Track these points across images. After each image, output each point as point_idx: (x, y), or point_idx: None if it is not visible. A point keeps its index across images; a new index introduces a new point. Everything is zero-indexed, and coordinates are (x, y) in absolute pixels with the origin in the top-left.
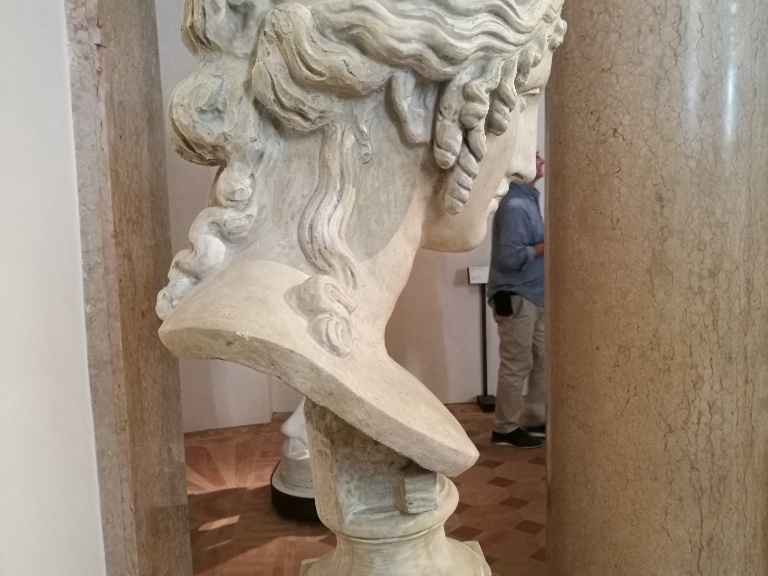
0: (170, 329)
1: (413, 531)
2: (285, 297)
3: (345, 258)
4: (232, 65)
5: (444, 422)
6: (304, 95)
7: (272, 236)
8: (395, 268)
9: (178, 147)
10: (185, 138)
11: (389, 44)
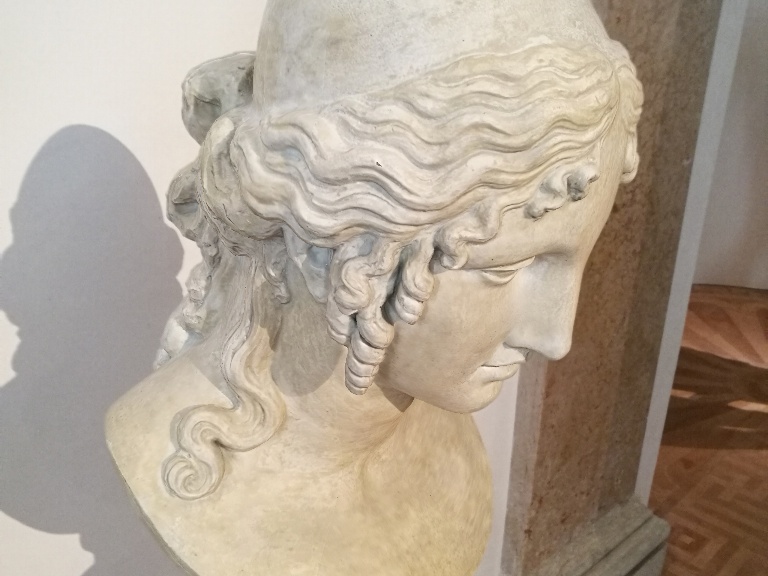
0: None
1: None
2: (176, 416)
3: (253, 394)
4: None
5: None
6: (218, 222)
7: (215, 342)
8: (336, 411)
9: None
10: None
11: (248, 202)
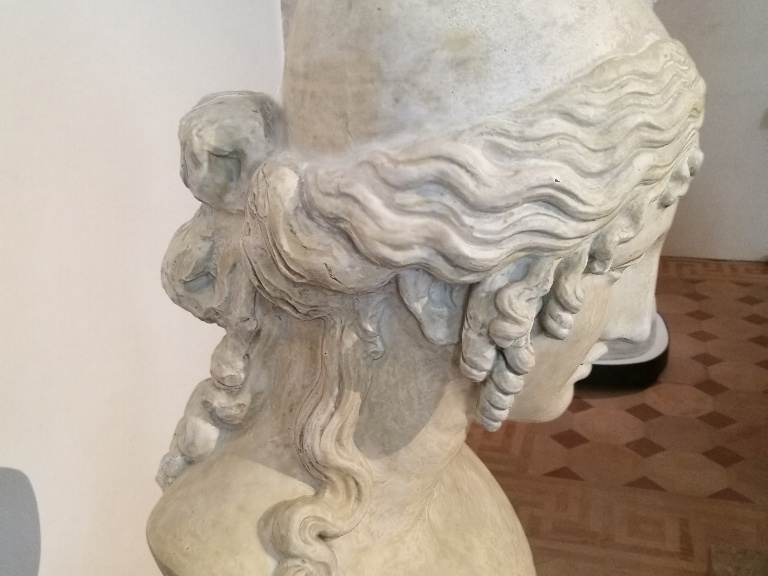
0: None
1: None
2: (260, 524)
3: (345, 469)
4: (224, 223)
5: None
6: (289, 287)
7: (267, 428)
8: (427, 459)
9: None
10: None
11: (379, 253)
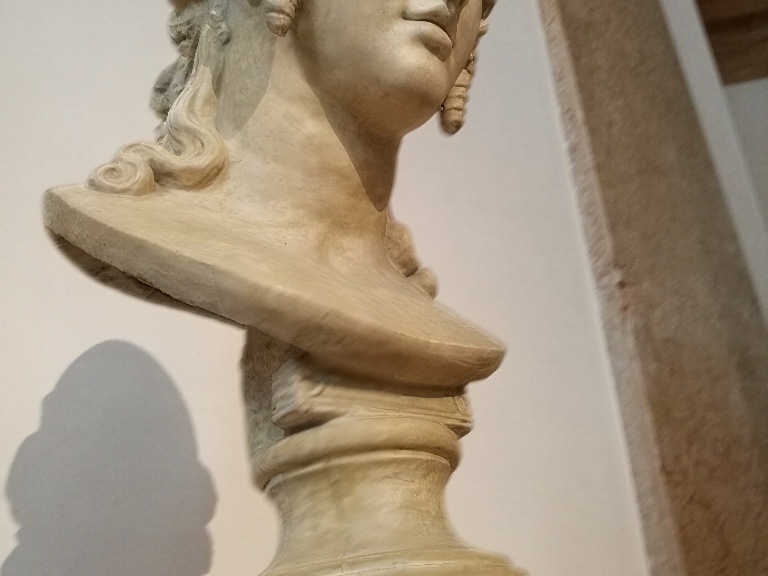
0: None
1: (285, 455)
2: None
3: (193, 131)
4: None
5: (256, 260)
6: None
7: None
8: (277, 134)
9: None
10: None
11: None
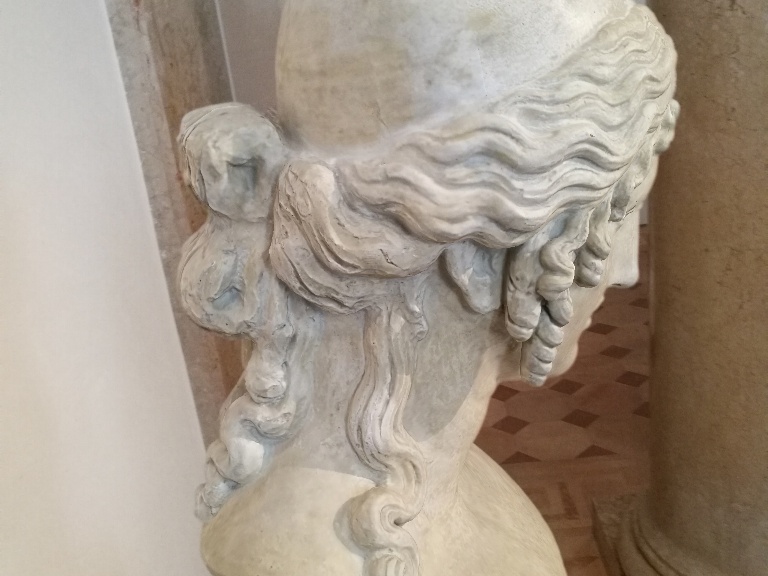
0: (209, 564)
1: None
2: (335, 525)
3: (404, 454)
4: (245, 233)
5: None
6: (336, 283)
7: (316, 432)
8: (466, 432)
9: None
10: None
11: (438, 228)
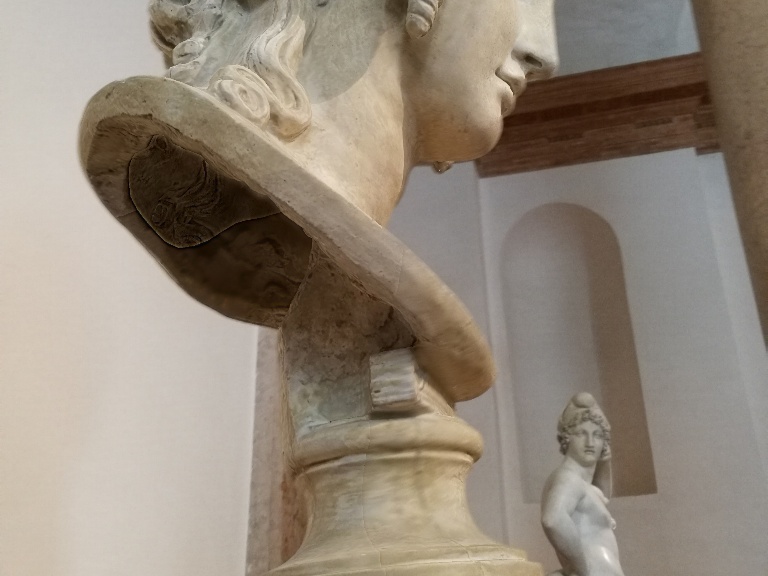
0: None
1: (384, 438)
2: None
3: (286, 79)
4: None
5: None
6: None
7: None
8: (365, 121)
9: (164, 64)
10: (157, 30)
11: None
